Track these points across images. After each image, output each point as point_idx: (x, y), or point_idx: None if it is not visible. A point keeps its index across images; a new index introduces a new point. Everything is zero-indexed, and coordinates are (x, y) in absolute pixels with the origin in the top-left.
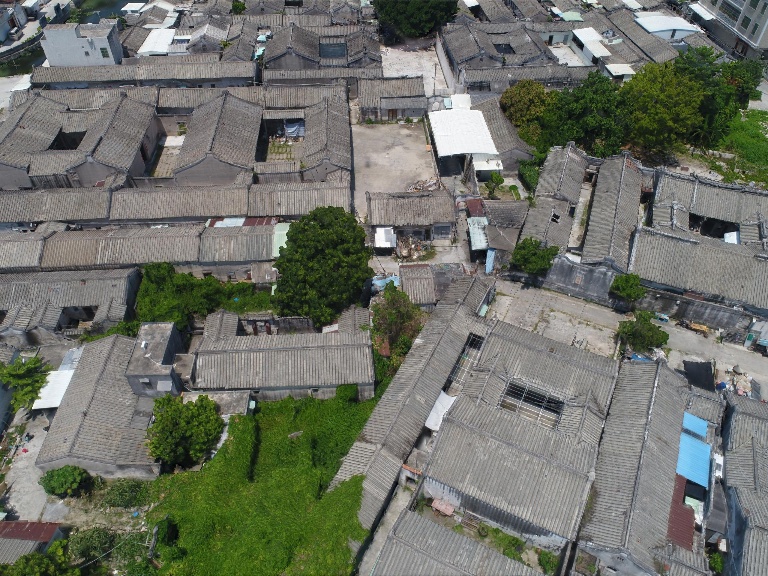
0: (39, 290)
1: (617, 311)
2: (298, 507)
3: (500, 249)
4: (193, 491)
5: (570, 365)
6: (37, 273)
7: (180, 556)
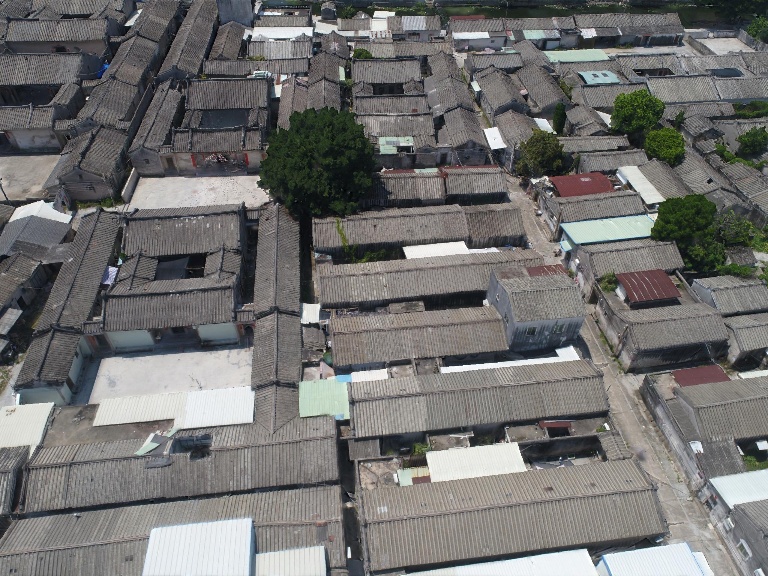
0: None
1: None
2: None
3: None
4: None
5: None
6: None
7: None
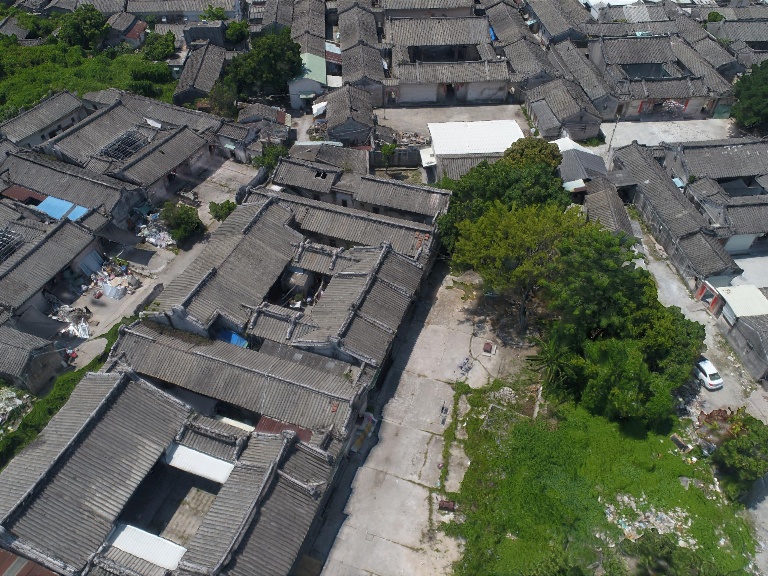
0: None
1: None
2: (108, 83)
3: None
4: (130, 58)
5: None
6: (291, 7)
7: (96, 55)
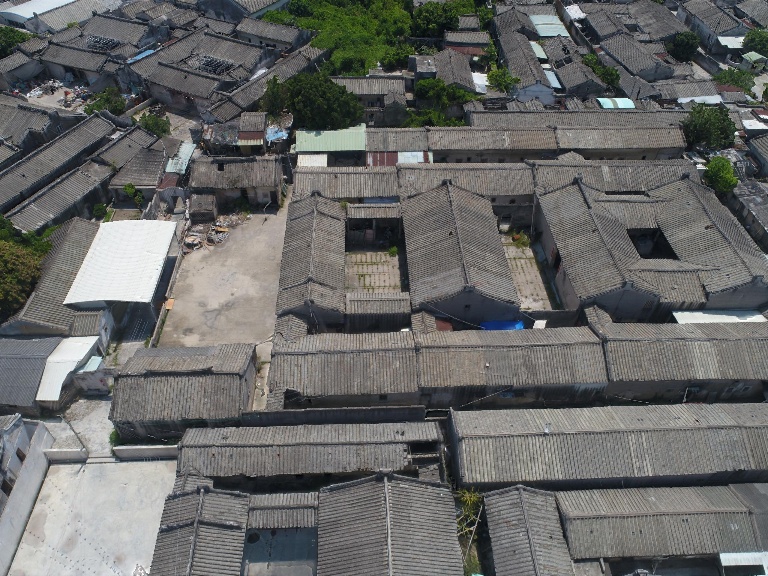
0: None
1: None
2: None
3: None
4: None
5: None
6: None
7: None
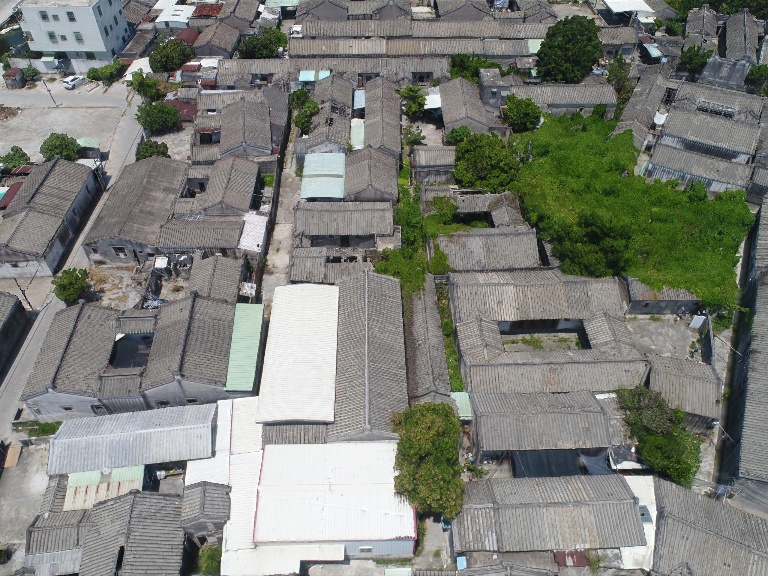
0: (396, 63)
1: (749, 93)
2: None
3: (672, 56)
4: (537, 137)
5: (735, 96)
6: None
7: None
